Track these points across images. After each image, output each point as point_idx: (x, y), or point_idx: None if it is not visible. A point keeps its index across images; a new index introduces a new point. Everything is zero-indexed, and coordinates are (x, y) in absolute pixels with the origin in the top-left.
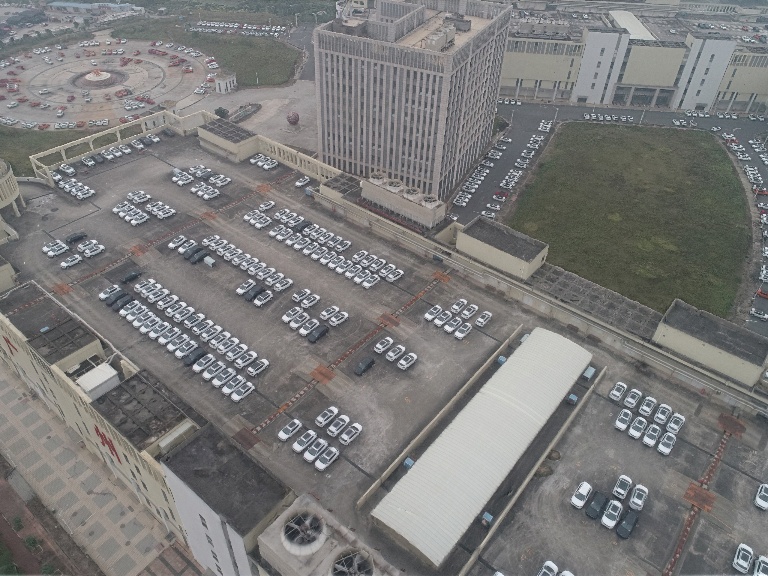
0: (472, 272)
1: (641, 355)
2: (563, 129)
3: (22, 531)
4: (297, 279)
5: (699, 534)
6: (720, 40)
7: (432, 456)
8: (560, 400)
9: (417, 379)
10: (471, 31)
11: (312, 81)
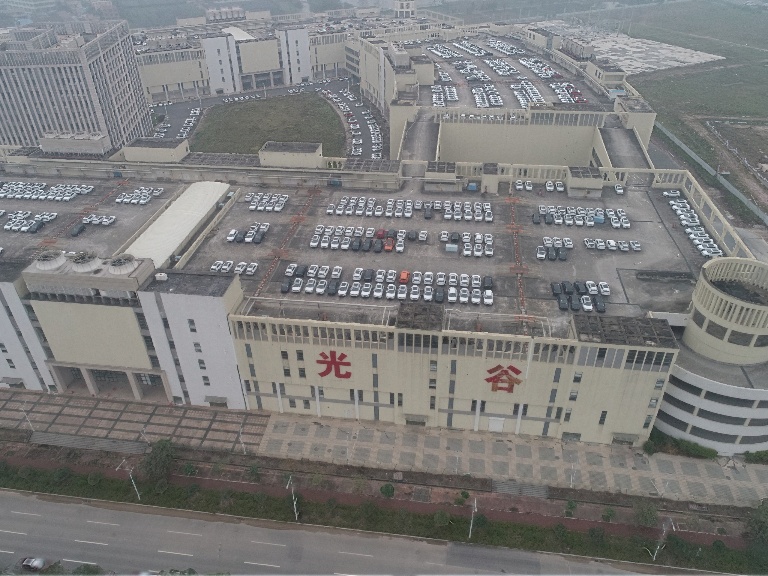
0: (143, 172)
1: (259, 177)
2: (209, 111)
3: None
4: (8, 210)
5: (299, 231)
6: (296, 29)
7: (135, 244)
8: (212, 205)
9: (119, 227)
10: None
11: None
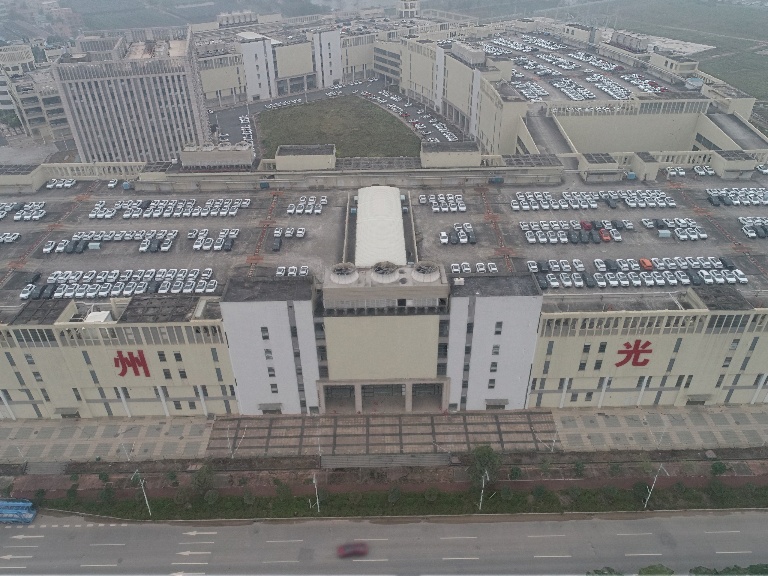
0: (296, 181)
1: (421, 179)
2: (258, 118)
3: (80, 486)
4: None
5: (502, 229)
6: (329, 32)
7: (361, 254)
8: (401, 210)
9: (315, 238)
10: (172, 48)
11: (7, 146)
